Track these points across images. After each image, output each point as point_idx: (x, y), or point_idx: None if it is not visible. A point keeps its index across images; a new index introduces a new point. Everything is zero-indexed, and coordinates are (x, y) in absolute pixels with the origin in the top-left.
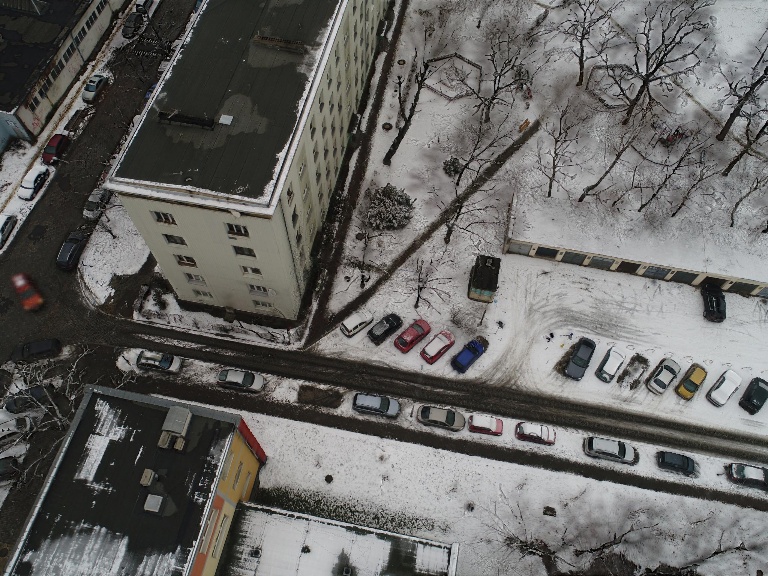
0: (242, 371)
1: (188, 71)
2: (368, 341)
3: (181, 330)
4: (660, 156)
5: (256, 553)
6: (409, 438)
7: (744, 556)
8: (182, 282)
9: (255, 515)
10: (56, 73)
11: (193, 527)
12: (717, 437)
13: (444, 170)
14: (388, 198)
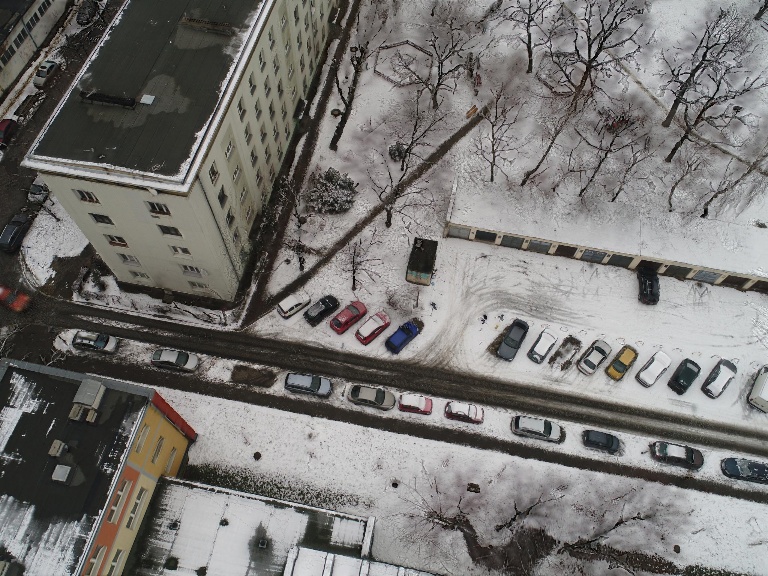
0: (176, 351)
1: (115, 52)
2: (304, 322)
3: (119, 311)
4: (605, 142)
5: (174, 525)
6: (339, 417)
7: (662, 532)
8: (118, 263)
9: (176, 489)
10: (6, 58)
11: (100, 496)
12: (644, 417)
13: (390, 155)
14: (330, 182)
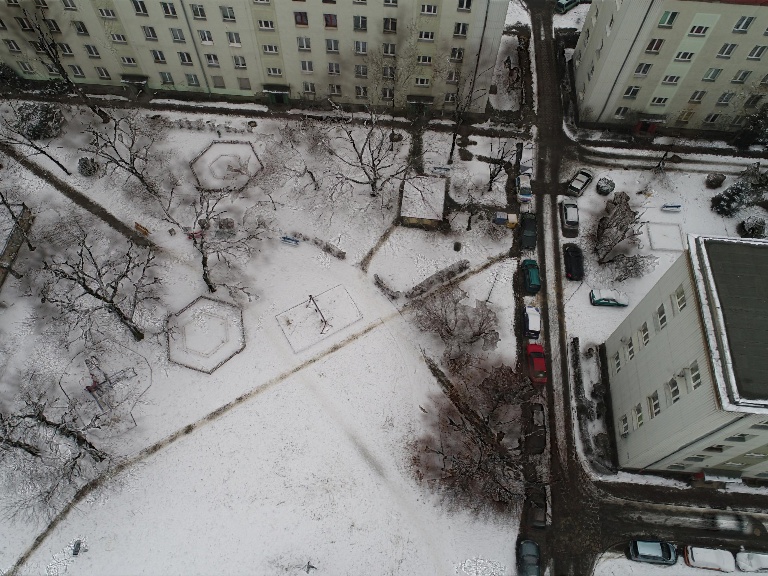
0: None
1: None
2: None
3: None
4: (77, 372)
5: None
6: None
7: None
8: None
9: None
10: None
11: None
12: None
13: None
14: None
